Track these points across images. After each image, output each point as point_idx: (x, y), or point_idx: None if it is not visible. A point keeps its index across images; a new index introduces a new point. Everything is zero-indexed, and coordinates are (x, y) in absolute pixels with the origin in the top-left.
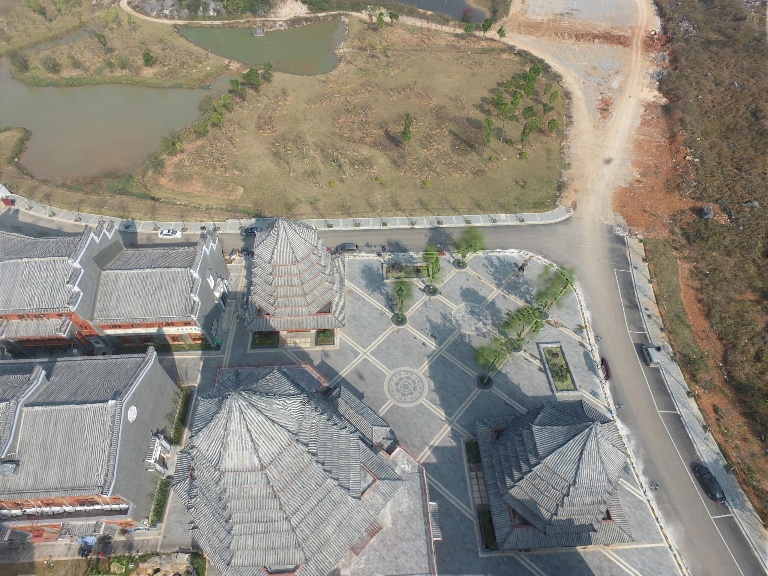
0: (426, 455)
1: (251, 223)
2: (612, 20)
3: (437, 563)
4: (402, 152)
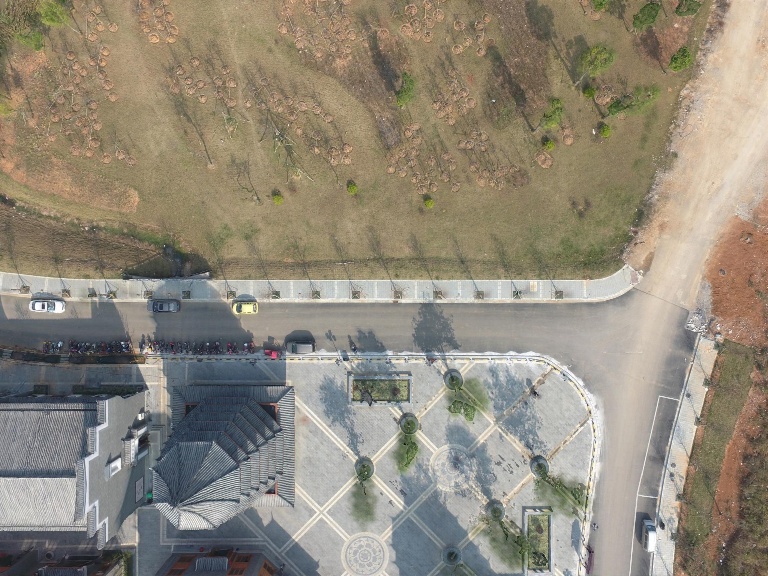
0: None
1: (160, 285)
2: None
3: None
4: (396, 110)
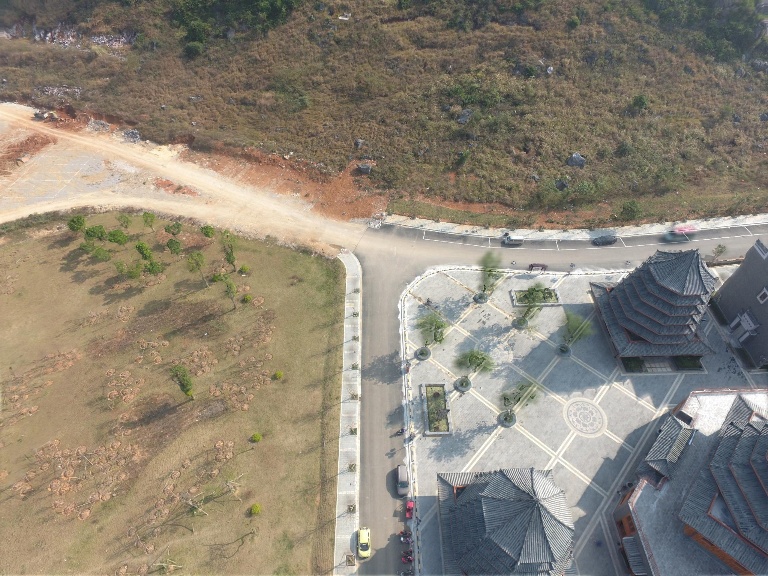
0: (647, 404)
1: None
2: None
3: None
4: (195, 404)
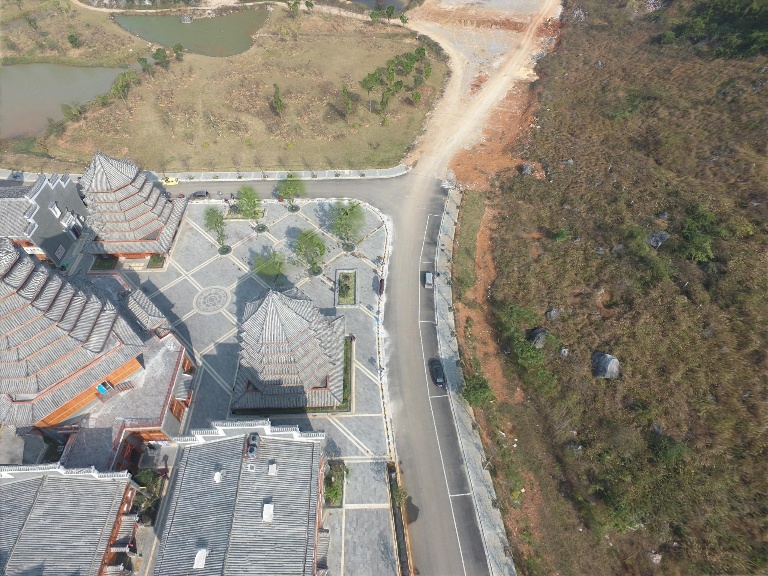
0: (210, 349)
1: None
2: (517, 9)
3: (190, 423)
4: (278, 120)
